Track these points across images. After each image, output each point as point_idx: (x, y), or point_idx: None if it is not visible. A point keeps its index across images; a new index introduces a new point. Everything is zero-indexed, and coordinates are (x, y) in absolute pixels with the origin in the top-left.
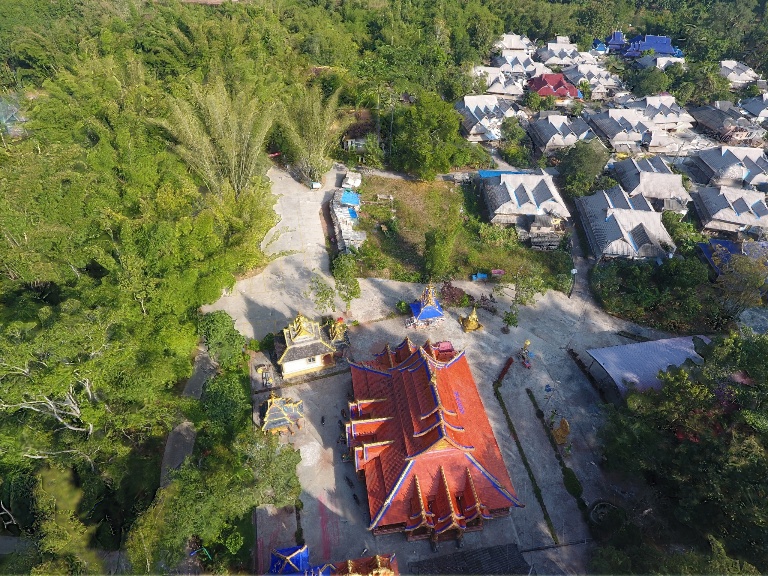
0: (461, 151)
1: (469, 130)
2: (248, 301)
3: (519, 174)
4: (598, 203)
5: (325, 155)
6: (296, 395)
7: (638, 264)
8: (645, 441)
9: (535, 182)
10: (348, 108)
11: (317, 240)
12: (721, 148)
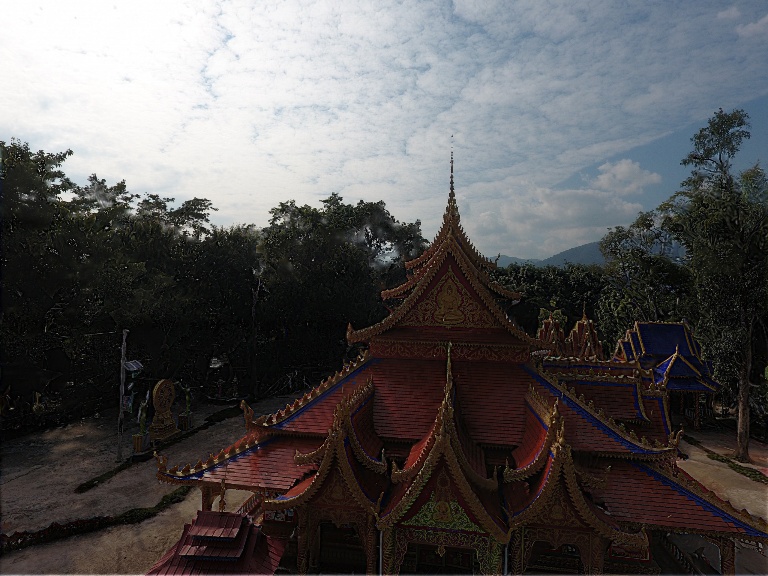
0: None
1: None
2: None
3: None
4: None
5: None
6: None
7: None
8: None
9: None
10: None
11: None
12: None
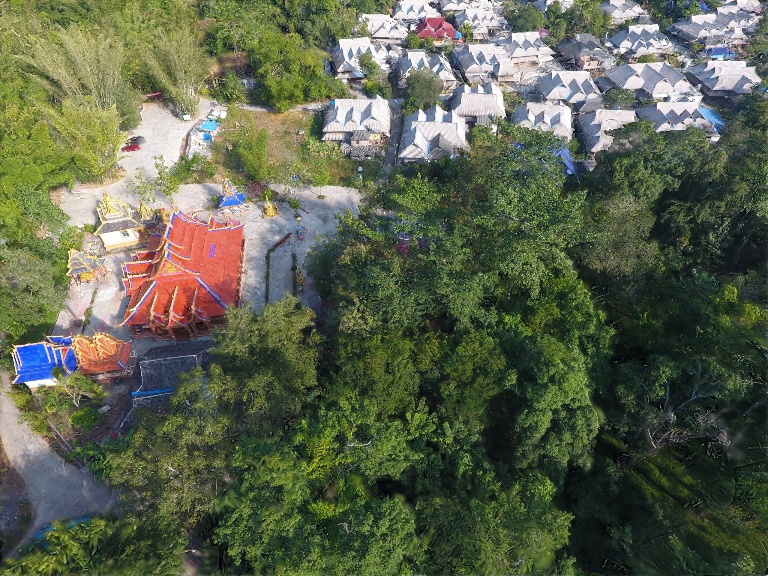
0: (316, 84)
1: (337, 69)
2: (98, 201)
3: (351, 99)
4: (413, 120)
5: (196, 92)
6: (112, 260)
7: (420, 163)
8: (324, 265)
9: (364, 105)
10: (209, 49)
11: (172, 158)
12: (552, 73)
